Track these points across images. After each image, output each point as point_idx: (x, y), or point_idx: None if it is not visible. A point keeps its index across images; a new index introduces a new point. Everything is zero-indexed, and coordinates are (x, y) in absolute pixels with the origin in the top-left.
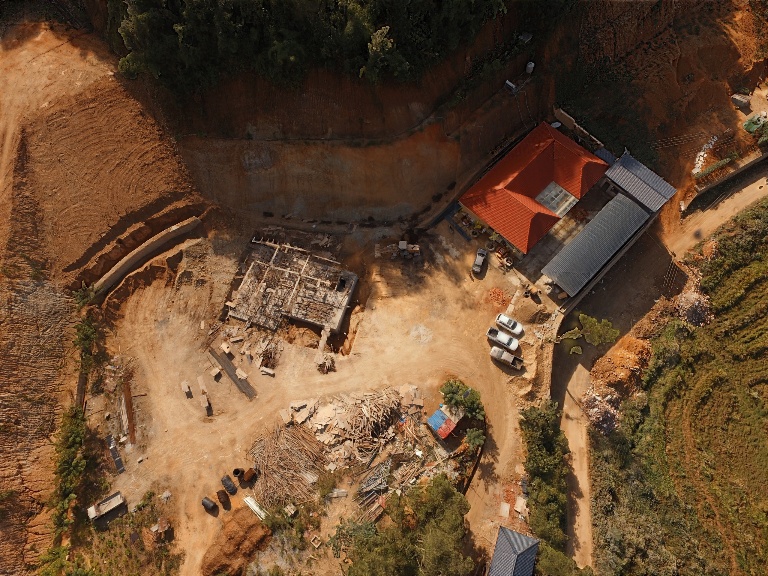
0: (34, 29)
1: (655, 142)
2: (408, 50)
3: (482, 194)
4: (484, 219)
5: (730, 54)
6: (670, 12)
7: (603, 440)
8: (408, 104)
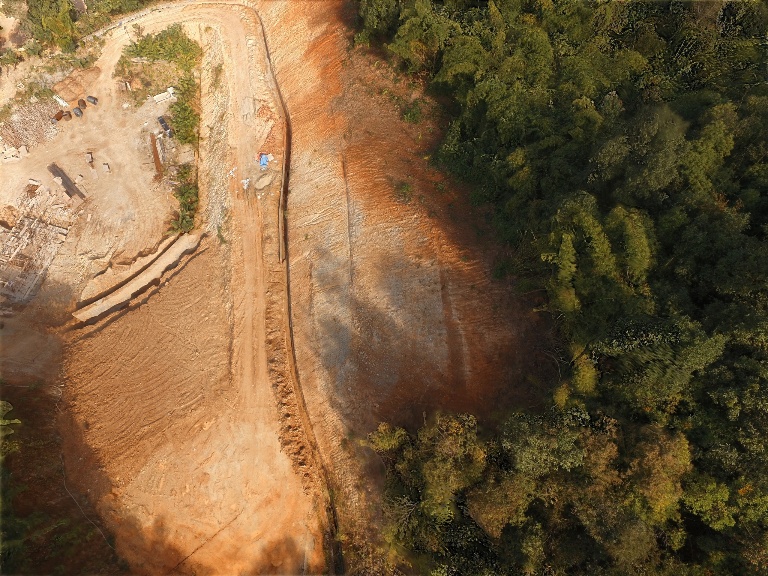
0: None
1: None
2: None
3: None
4: None
5: None
6: None
7: None
8: None
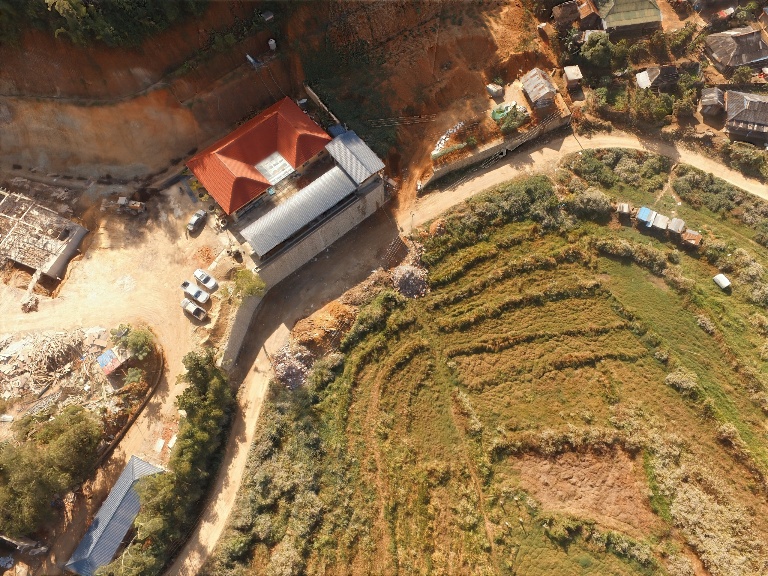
0: None
1: (378, 120)
2: (117, 17)
3: (200, 158)
4: (201, 181)
5: (488, 45)
6: (436, 2)
7: (285, 393)
8: (130, 69)
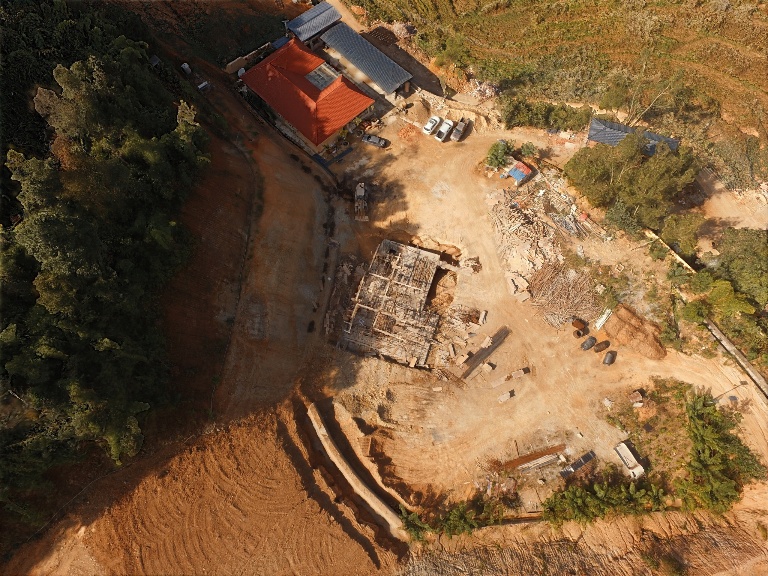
0: None
1: (277, 5)
2: None
3: (317, 123)
4: (339, 127)
5: None
6: None
7: None
8: (224, 153)
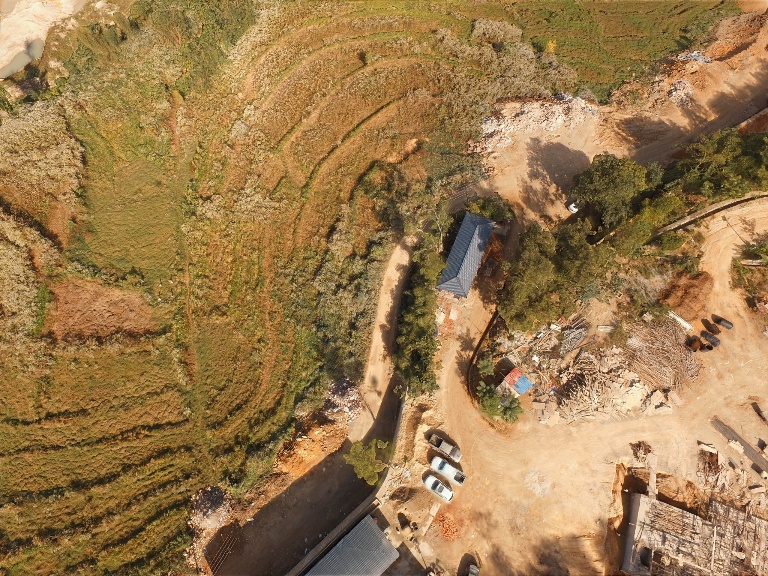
0: None
1: None
2: None
3: None
4: None
5: None
6: None
7: (350, 372)
8: None
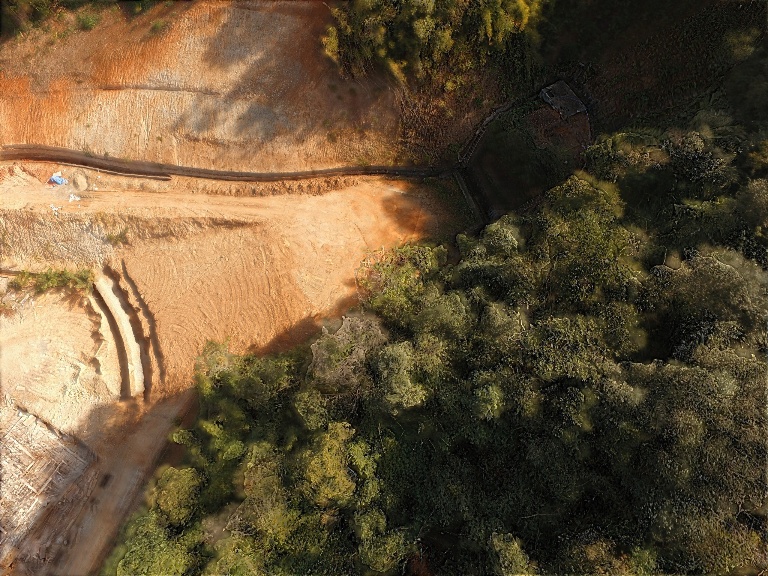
0: (408, 227)
1: None
2: None
3: None
4: None
5: None
6: None
7: None
8: None
